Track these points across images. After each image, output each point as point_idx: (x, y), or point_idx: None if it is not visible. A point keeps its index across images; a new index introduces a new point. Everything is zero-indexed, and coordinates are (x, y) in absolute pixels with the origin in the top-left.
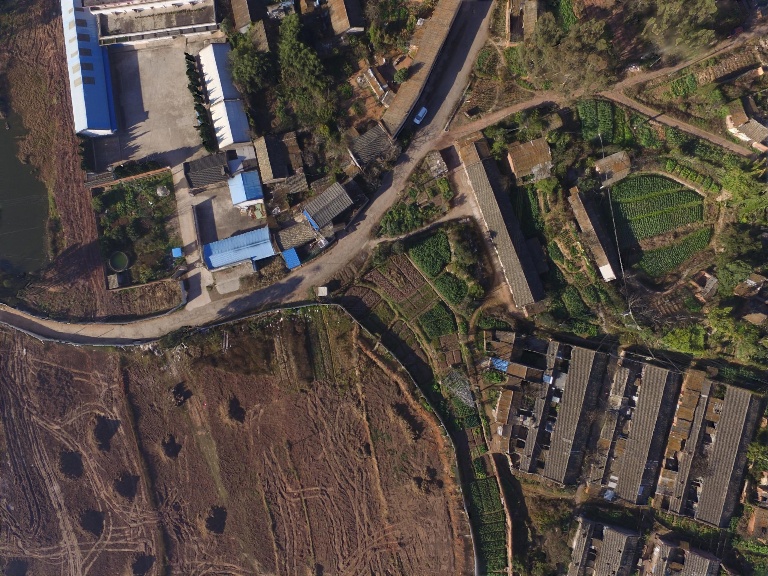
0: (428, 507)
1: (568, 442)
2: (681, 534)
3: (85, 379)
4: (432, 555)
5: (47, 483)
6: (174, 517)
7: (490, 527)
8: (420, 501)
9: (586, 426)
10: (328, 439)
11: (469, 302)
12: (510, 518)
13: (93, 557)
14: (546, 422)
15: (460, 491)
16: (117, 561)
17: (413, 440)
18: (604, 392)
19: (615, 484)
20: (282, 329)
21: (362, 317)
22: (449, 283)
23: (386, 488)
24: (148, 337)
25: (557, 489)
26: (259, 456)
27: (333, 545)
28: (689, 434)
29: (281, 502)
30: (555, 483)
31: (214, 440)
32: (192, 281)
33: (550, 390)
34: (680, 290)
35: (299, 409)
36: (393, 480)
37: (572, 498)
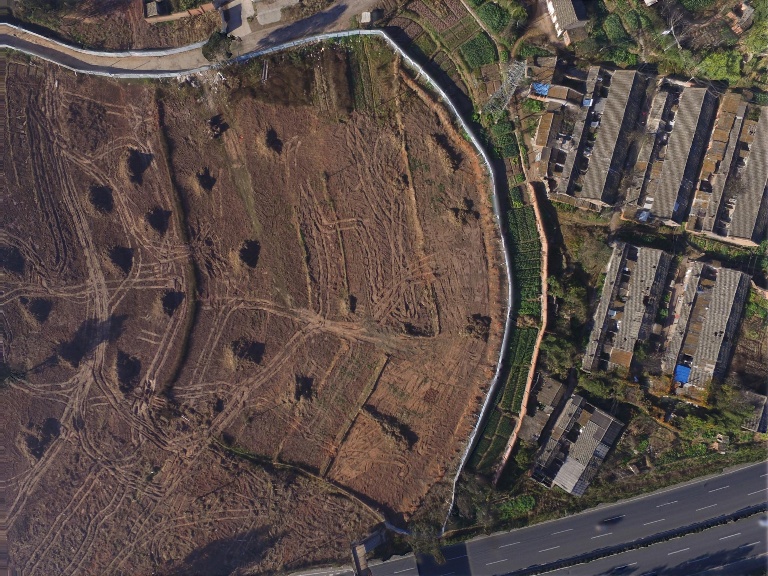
0: (464, 238)
1: (607, 160)
2: (713, 257)
3: (118, 113)
4: (466, 286)
5: (75, 219)
6: (206, 252)
7: (525, 255)
8: (456, 232)
9: (624, 148)
10: (366, 170)
11: (512, 25)
12: (546, 241)
13: (120, 295)
14: (584, 147)
15: (497, 220)
16: (145, 299)
17: (451, 169)
18: (641, 121)
19: (651, 205)
20: (323, 59)
21: (404, 48)
22: (492, 11)
23: (423, 218)
24: (185, 68)
25: (593, 213)
26: (295, 188)
27: (367, 276)
28: (724, 155)
29: (316, 235)
30: (591, 207)
31: (250, 173)
32: (232, 12)
33: (590, 113)
34: (717, 23)
35: (338, 140)
36: (430, 210)
37: (607, 225)
